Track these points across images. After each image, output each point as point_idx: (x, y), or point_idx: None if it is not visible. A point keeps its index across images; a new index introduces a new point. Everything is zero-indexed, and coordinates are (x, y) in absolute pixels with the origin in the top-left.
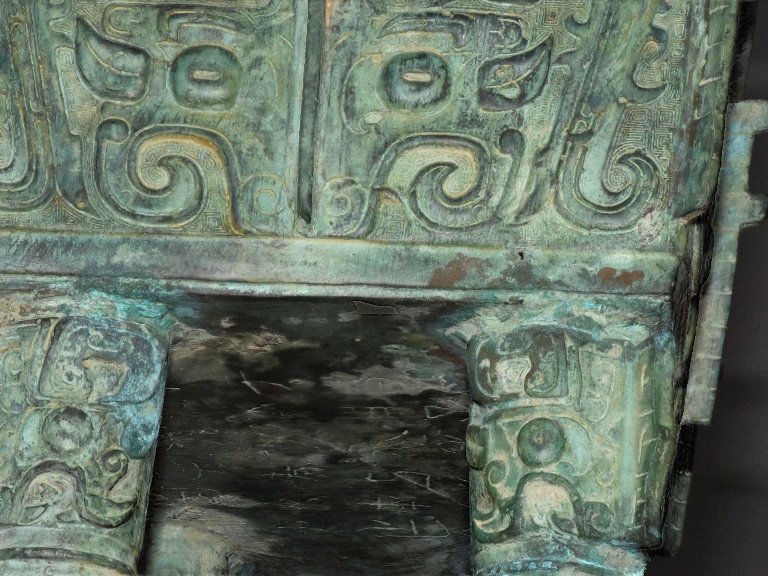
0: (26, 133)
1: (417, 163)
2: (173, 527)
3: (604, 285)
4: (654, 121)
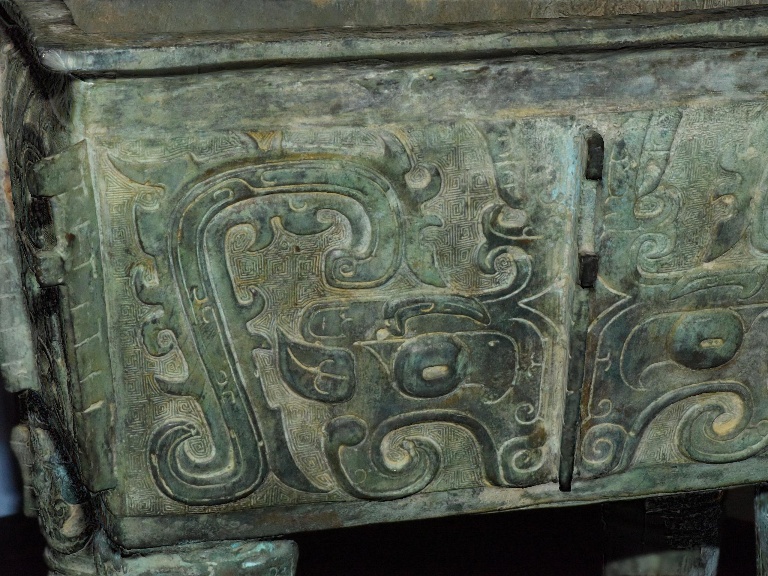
0: None
1: None
2: None
3: None
4: None
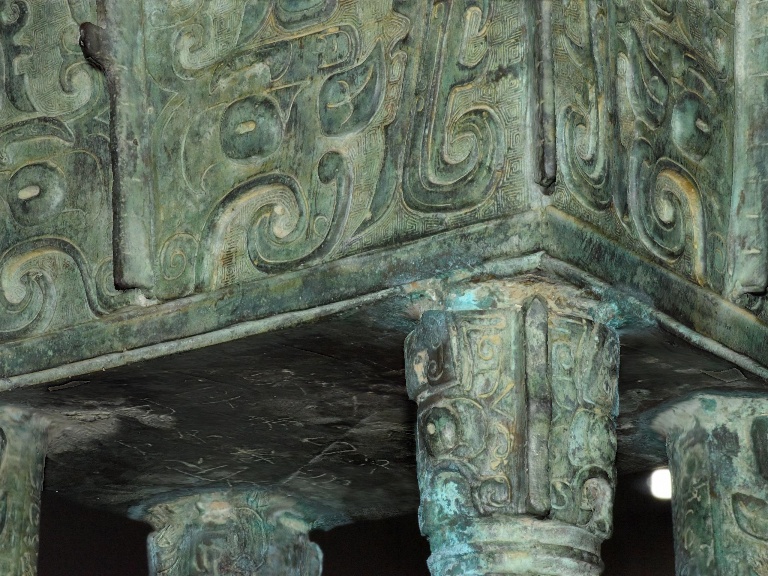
0: (603, 131)
1: None
2: (47, 420)
3: None
4: None
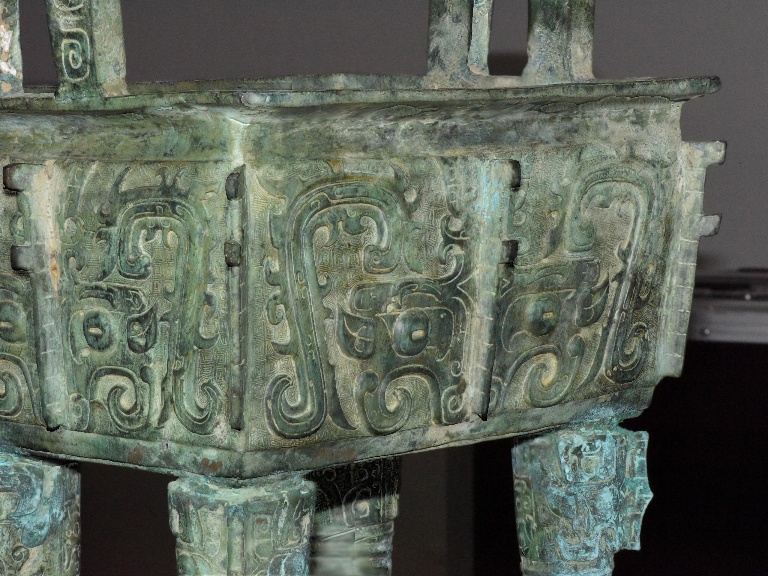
0: None
1: (109, 384)
2: None
3: (205, 470)
4: (216, 360)
